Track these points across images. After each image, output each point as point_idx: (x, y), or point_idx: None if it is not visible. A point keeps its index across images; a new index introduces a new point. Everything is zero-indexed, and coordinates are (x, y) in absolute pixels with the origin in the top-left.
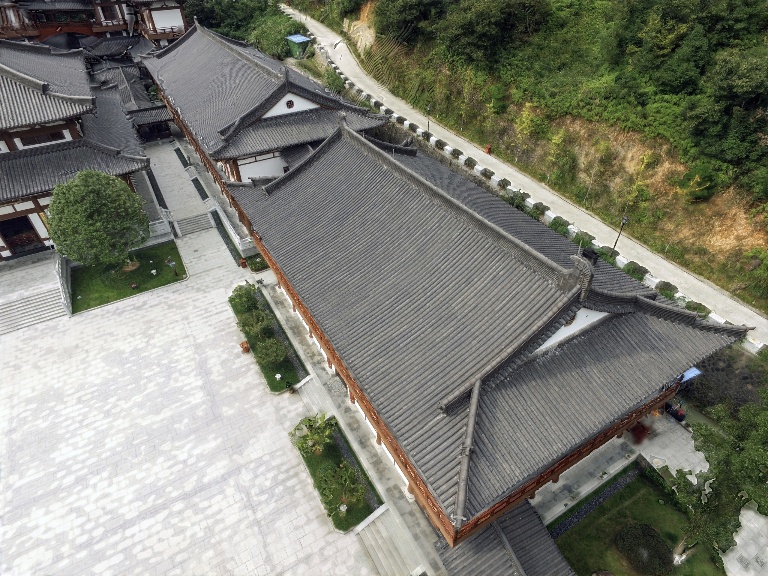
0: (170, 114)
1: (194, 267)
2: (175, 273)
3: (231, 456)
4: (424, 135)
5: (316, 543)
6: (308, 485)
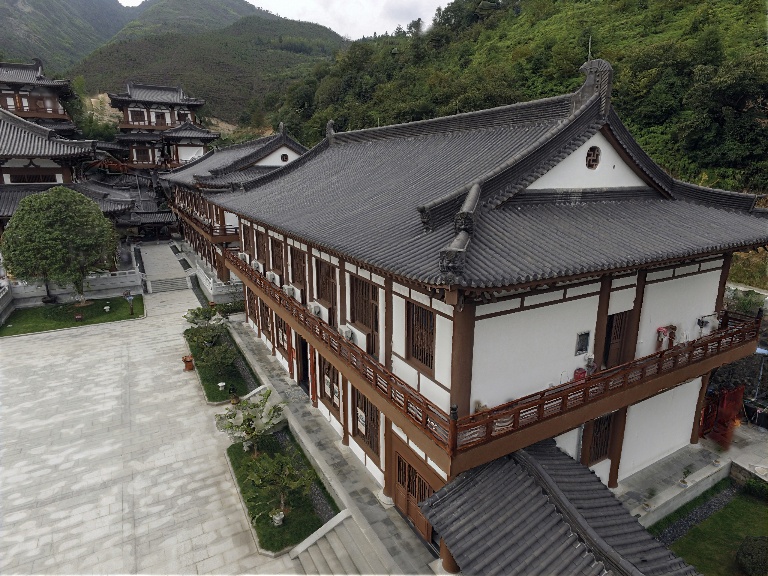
0: (174, 217)
1: (155, 311)
2: (131, 311)
3: (127, 462)
4: None
5: (223, 569)
6: (231, 496)
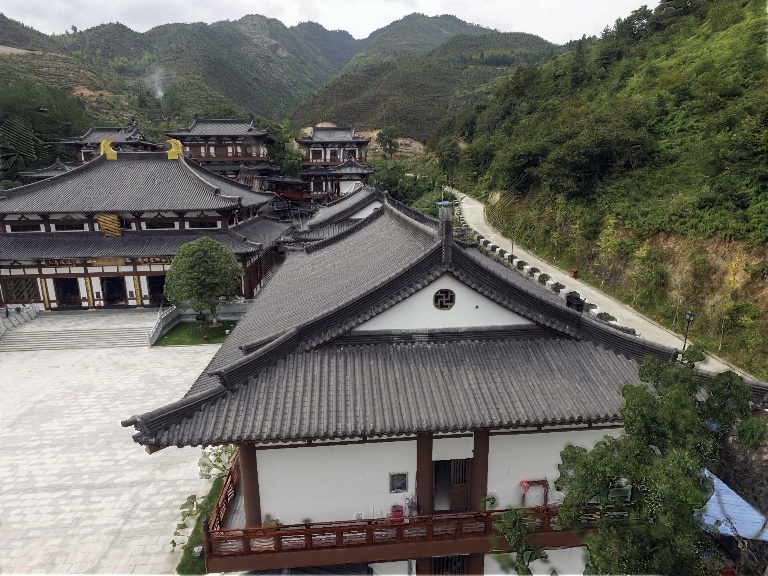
0: None
1: None
2: None
3: (155, 470)
4: (509, 258)
5: None
6: (192, 519)
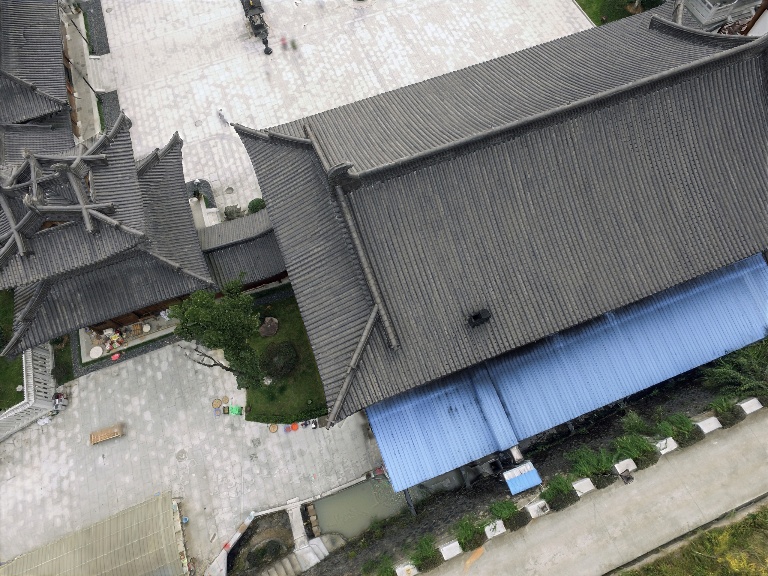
0: None
1: None
2: None
3: None
4: None
5: None
6: None
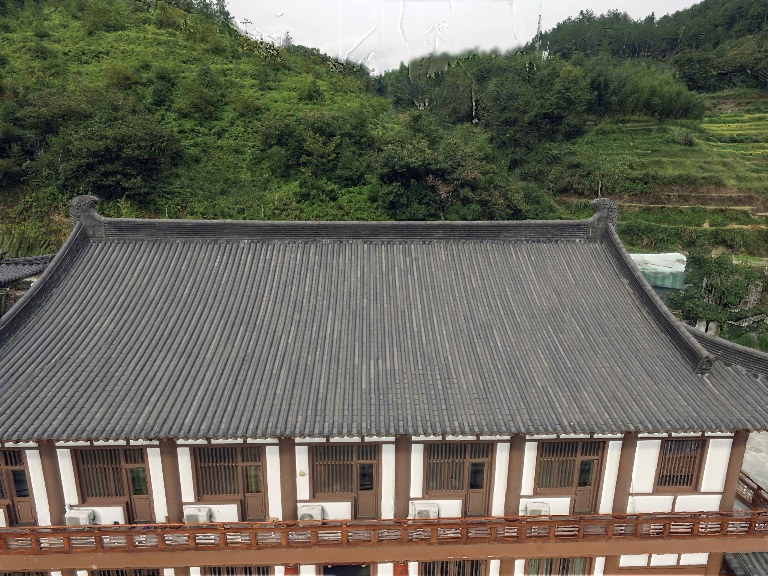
0: None
1: None
2: None
3: None
4: None
5: None
6: None
